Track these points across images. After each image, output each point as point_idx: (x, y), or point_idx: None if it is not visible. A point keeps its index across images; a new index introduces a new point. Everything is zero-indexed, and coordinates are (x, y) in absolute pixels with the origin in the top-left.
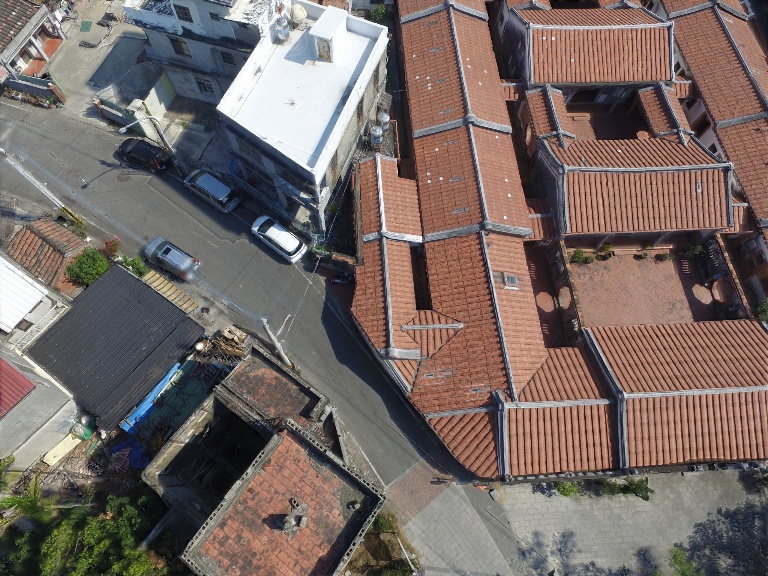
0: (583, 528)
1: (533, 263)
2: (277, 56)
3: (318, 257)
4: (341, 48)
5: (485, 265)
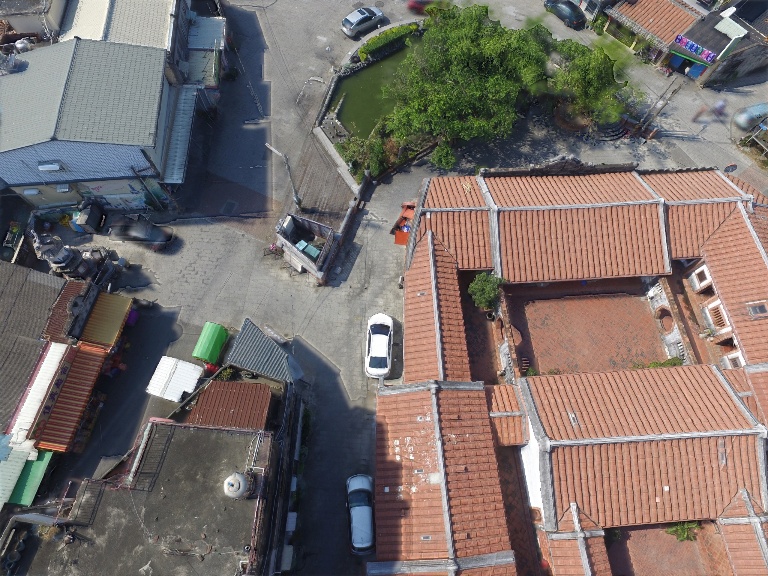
0: None
1: None
2: None
3: None
4: None
5: None
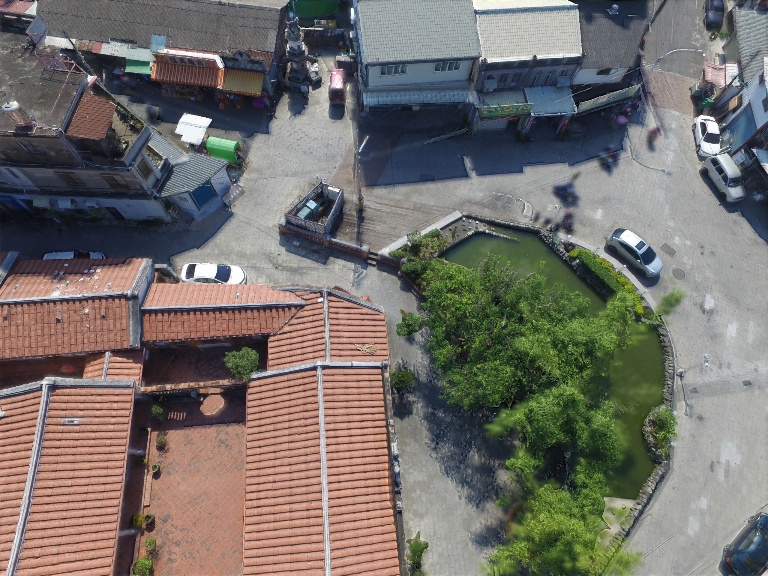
0: None
1: None
2: None
3: None
4: None
5: None
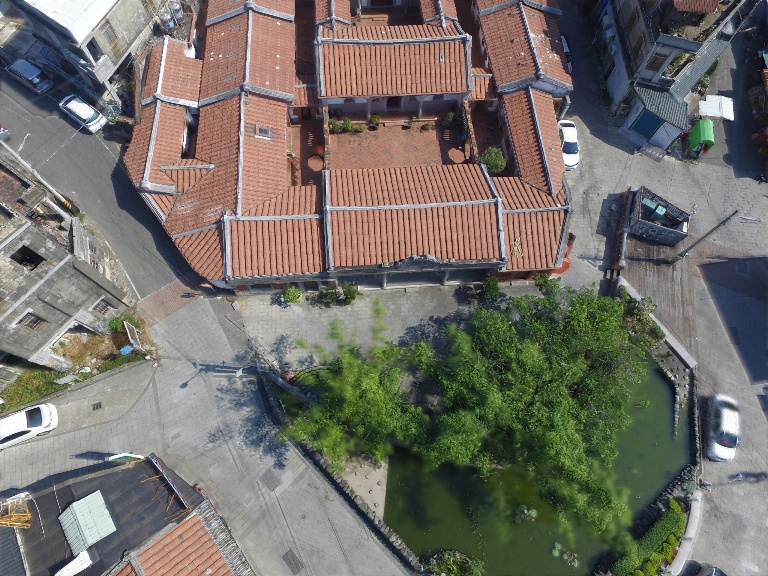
0: (309, 331)
1: (312, 134)
2: None
3: (111, 124)
4: None
5: (239, 118)
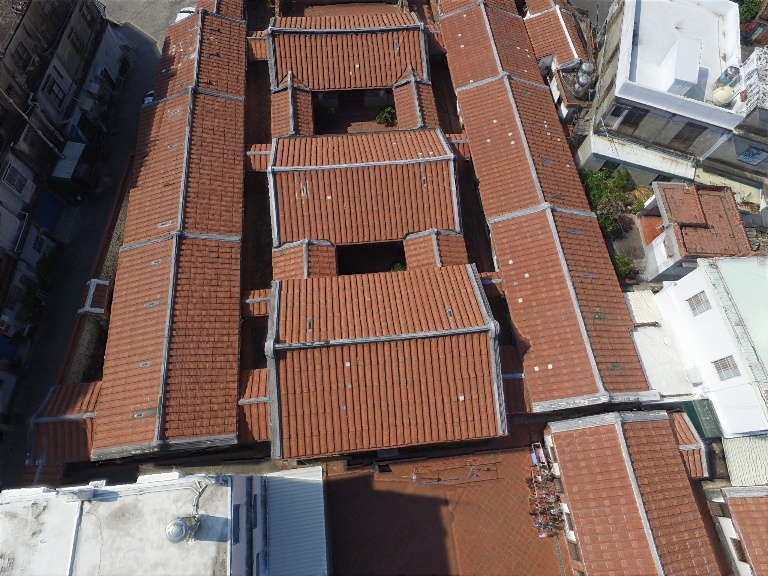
0: None
1: None
2: (716, 72)
3: None
4: (660, 82)
5: None
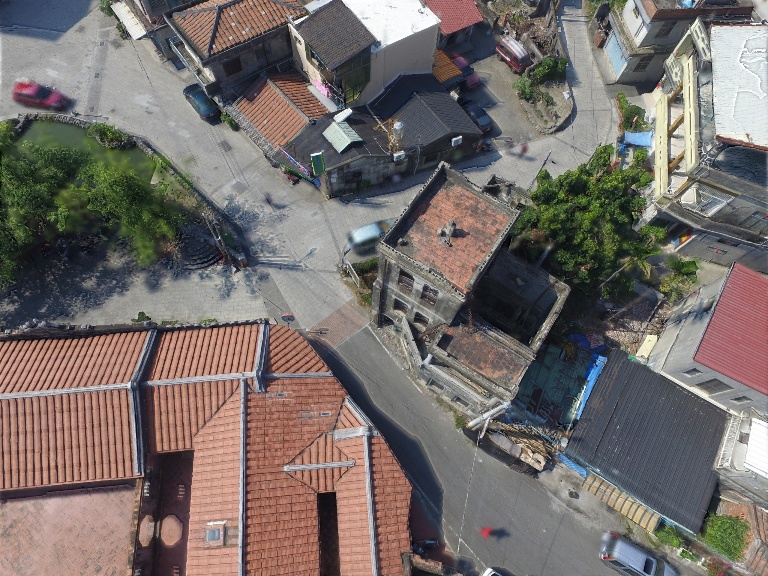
0: (202, 301)
1: None
2: None
3: (459, 574)
4: None
5: (246, 553)
